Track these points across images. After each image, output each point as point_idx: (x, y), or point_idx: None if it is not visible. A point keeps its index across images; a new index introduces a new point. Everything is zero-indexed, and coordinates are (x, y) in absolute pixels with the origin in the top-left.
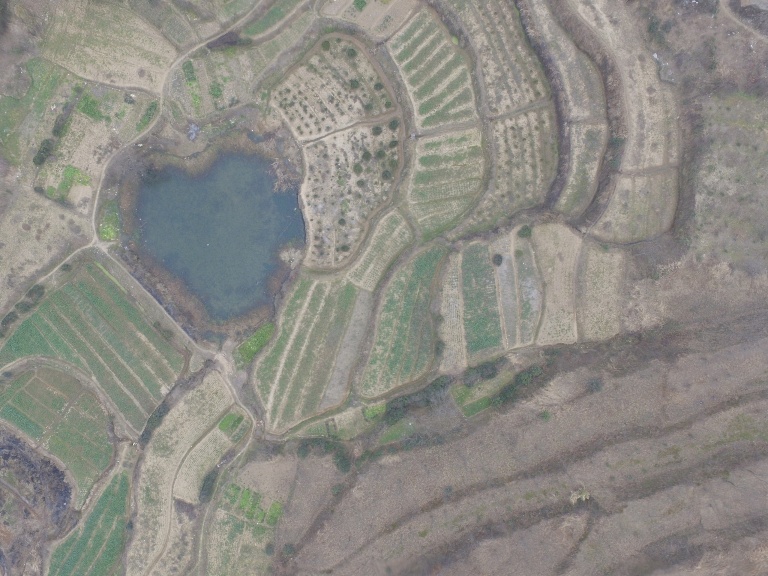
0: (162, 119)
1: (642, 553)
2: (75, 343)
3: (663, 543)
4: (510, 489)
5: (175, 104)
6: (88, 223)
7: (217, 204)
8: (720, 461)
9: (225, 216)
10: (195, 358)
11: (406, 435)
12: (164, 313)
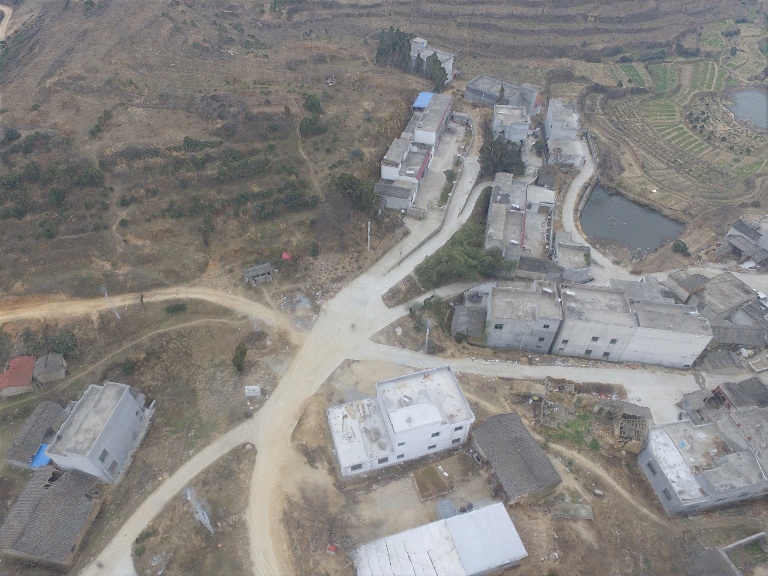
0: None
1: (569, 6)
2: None
3: (562, 7)
4: (613, 28)
5: None
6: None
7: None
8: (541, 20)
9: None
10: None
11: (654, 49)
12: None
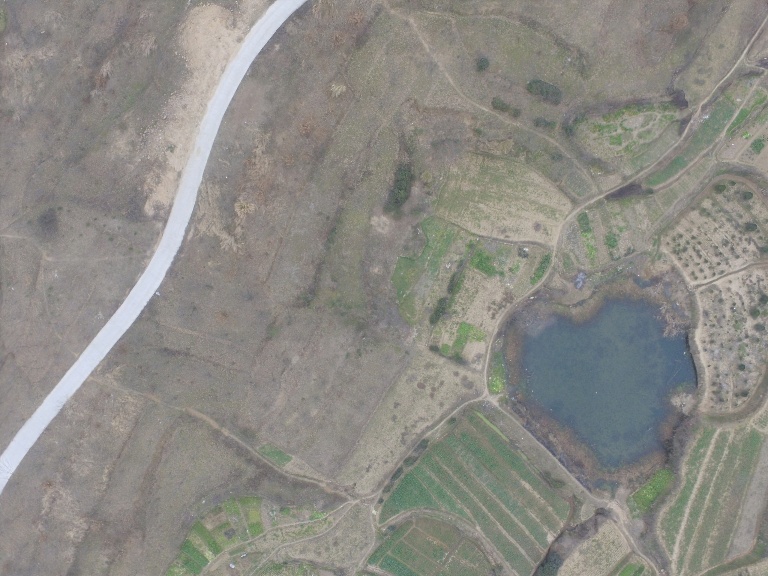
0: (554, 271)
1: None
2: (459, 494)
3: None
4: None
5: (568, 255)
6: (481, 378)
7: (602, 350)
8: None
9: (609, 361)
10: (587, 507)
11: None
12: (558, 464)
